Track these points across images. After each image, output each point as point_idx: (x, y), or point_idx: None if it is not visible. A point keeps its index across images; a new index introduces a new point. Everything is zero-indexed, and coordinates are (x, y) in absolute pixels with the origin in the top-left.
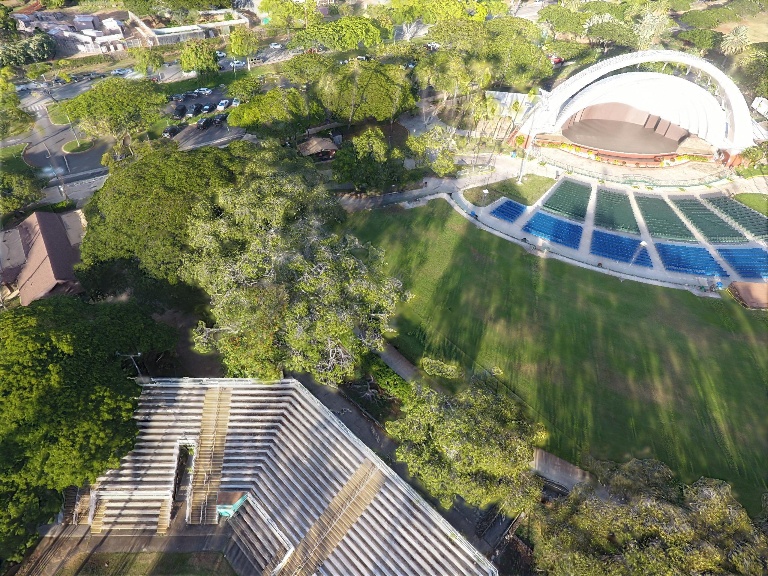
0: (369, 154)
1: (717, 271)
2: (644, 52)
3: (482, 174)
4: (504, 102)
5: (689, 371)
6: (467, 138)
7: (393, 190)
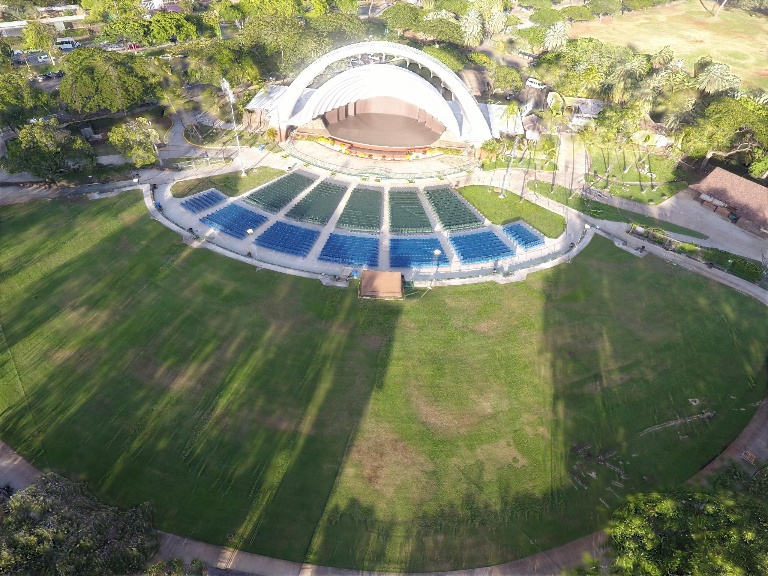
0: (37, 144)
1: (367, 261)
2: (361, 43)
3: (213, 166)
4: (272, 95)
5: (237, 358)
6: (226, 131)
7: (92, 181)
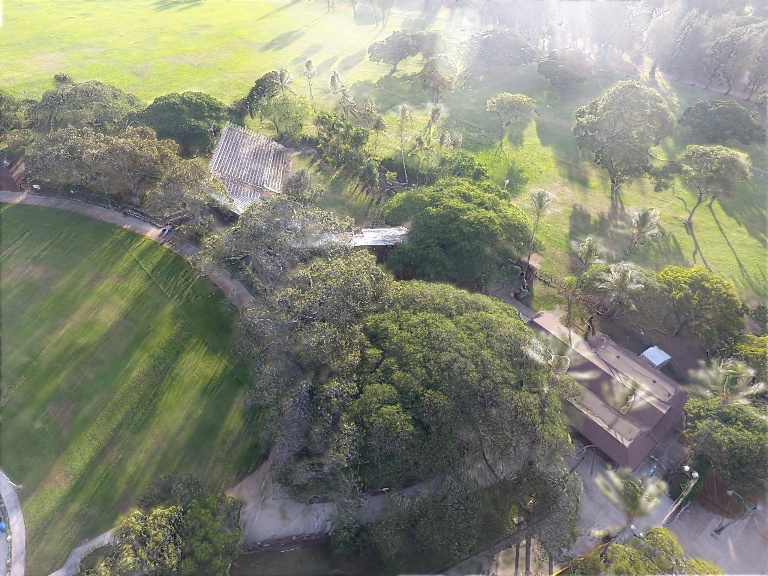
0: None
1: None
2: None
3: None
4: None
5: None
6: None
7: None
